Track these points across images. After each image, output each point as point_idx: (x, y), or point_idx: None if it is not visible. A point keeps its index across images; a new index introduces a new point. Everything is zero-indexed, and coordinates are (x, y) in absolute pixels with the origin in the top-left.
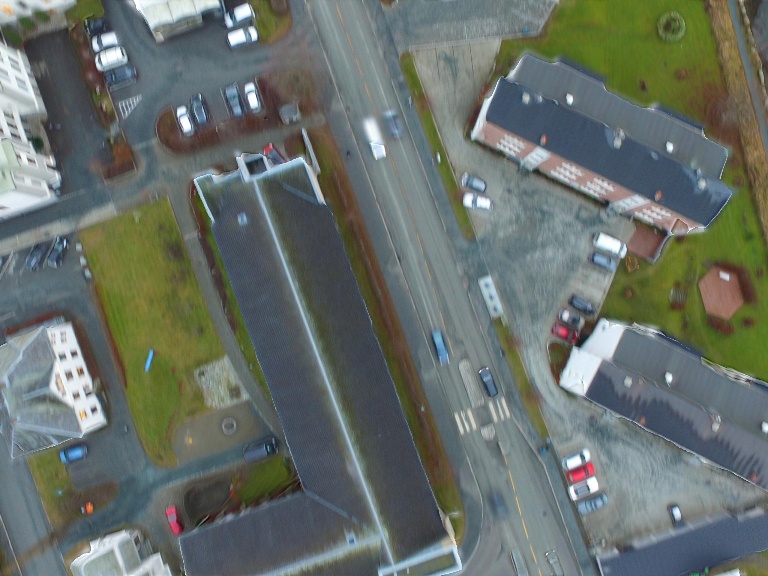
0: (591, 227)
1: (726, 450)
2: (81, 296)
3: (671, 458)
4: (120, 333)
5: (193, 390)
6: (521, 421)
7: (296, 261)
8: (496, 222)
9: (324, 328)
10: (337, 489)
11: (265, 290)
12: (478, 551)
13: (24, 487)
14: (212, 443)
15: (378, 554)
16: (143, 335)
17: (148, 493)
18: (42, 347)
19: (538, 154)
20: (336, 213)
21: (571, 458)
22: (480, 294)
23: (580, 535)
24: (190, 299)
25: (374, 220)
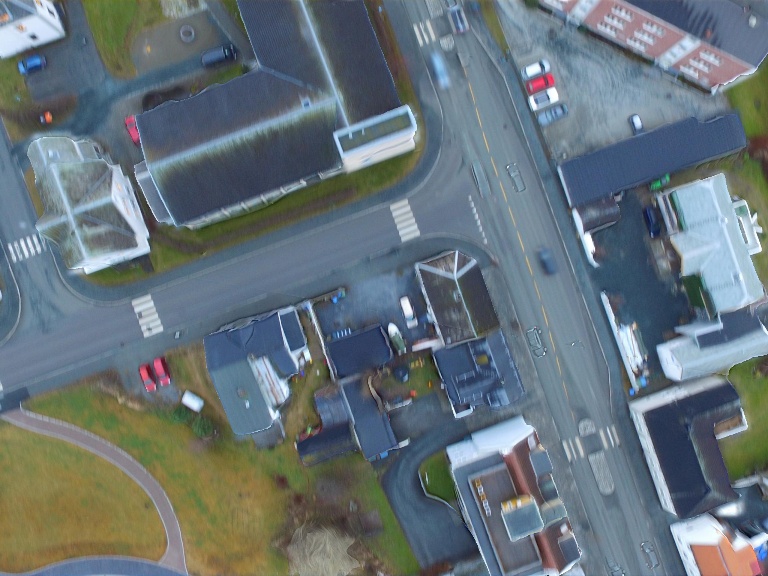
0: None
1: (680, 6)
2: None
3: (631, 71)
4: None
5: None
6: (480, 32)
7: None
8: None
9: None
10: (292, 56)
11: None
12: (439, 164)
13: None
14: (170, 52)
15: (333, 120)
16: None
17: (107, 105)
18: None
19: None
20: None
21: (530, 65)
22: None
23: (541, 147)
24: None
25: None
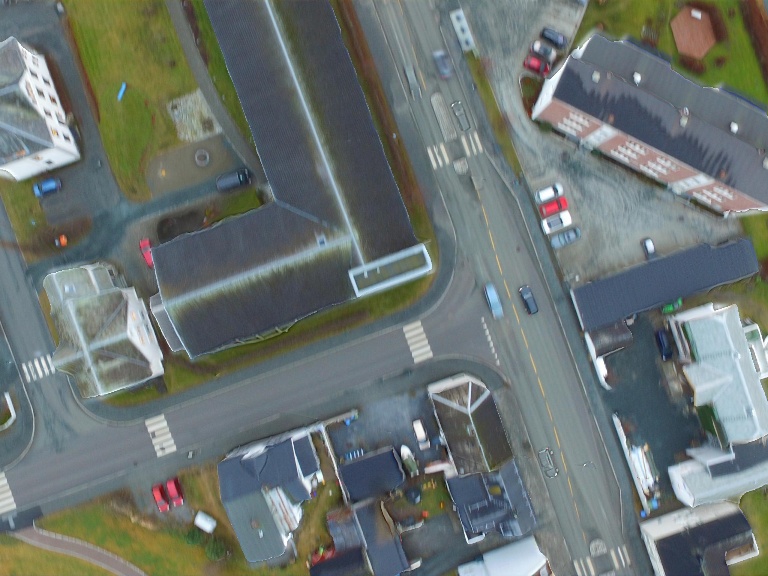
0: None
1: (695, 147)
2: (54, 31)
3: (644, 194)
4: (93, 67)
5: (166, 123)
6: (494, 155)
7: None
8: None
9: (293, 30)
10: (307, 193)
11: None
12: (452, 286)
13: None
14: (185, 176)
15: (349, 257)
16: (116, 68)
17: (122, 228)
18: (12, 55)
19: None
20: None
21: (544, 190)
22: (452, 27)
23: (554, 270)
24: (162, 32)
25: None
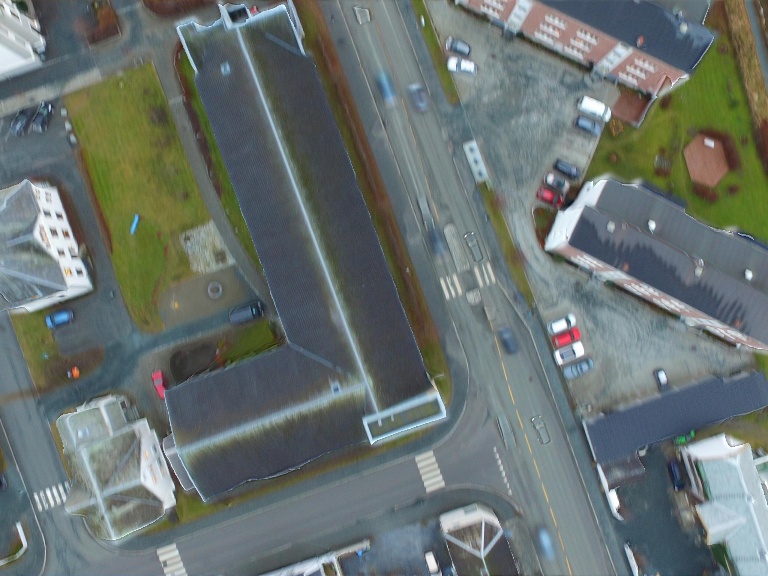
0: (575, 92)
1: (709, 296)
2: (66, 162)
3: (657, 323)
4: (105, 198)
5: (179, 255)
6: (506, 286)
7: (279, 109)
8: (481, 87)
9: (307, 177)
10: (321, 339)
11: (248, 139)
12: (464, 417)
13: (10, 354)
14: (198, 308)
15: (363, 403)
16: (128, 200)
17: (134, 358)
18: (26, 199)
19: (521, 6)
20: (320, 77)
21: (556, 322)
22: (465, 159)
23: (566, 400)
24: (175, 164)
25: (359, 84)
